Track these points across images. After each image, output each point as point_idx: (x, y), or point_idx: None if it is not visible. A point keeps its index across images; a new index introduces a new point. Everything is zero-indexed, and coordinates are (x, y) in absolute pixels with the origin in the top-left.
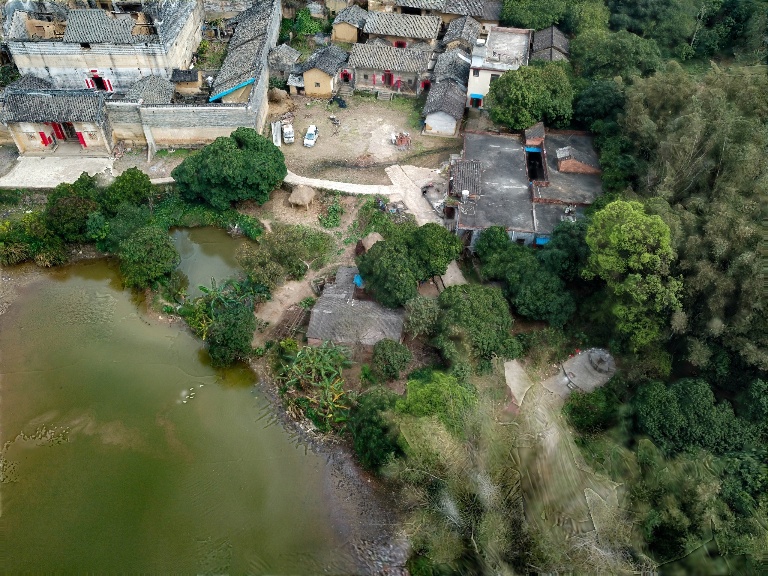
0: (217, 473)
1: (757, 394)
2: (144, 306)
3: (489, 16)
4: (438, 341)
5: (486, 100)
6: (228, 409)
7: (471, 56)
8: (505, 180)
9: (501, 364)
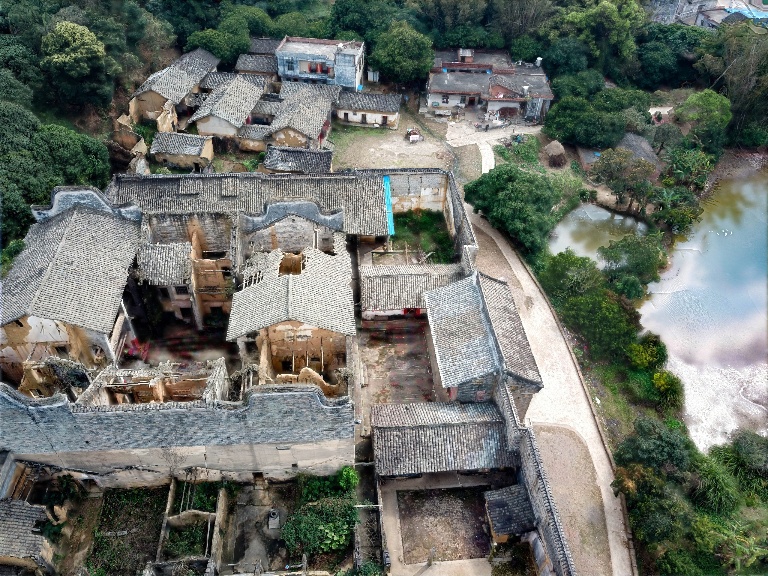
0: (762, 214)
1: (651, 30)
2: (663, 276)
3: (213, 63)
4: (647, 115)
5: (410, 66)
6: (717, 219)
7: (342, 62)
8: None
9: (661, 91)
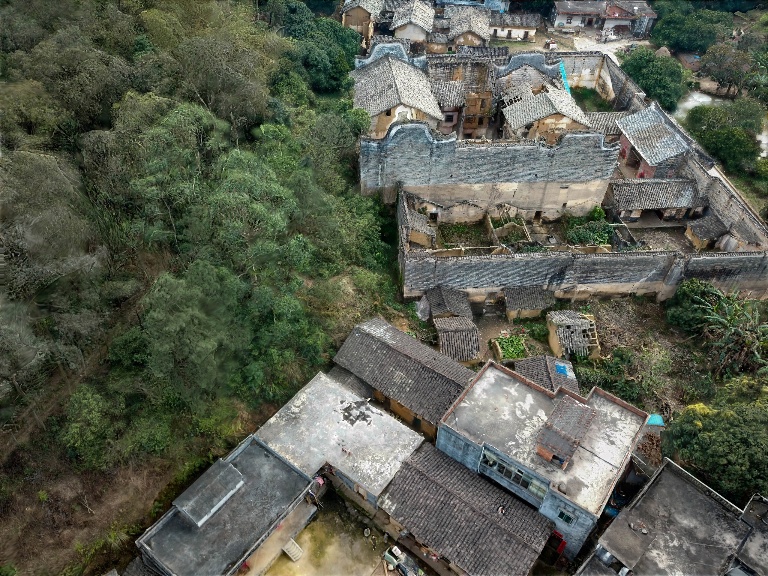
0: None
1: None
2: (762, 133)
3: None
4: None
5: None
6: None
7: None
8: (604, 6)
9: None
